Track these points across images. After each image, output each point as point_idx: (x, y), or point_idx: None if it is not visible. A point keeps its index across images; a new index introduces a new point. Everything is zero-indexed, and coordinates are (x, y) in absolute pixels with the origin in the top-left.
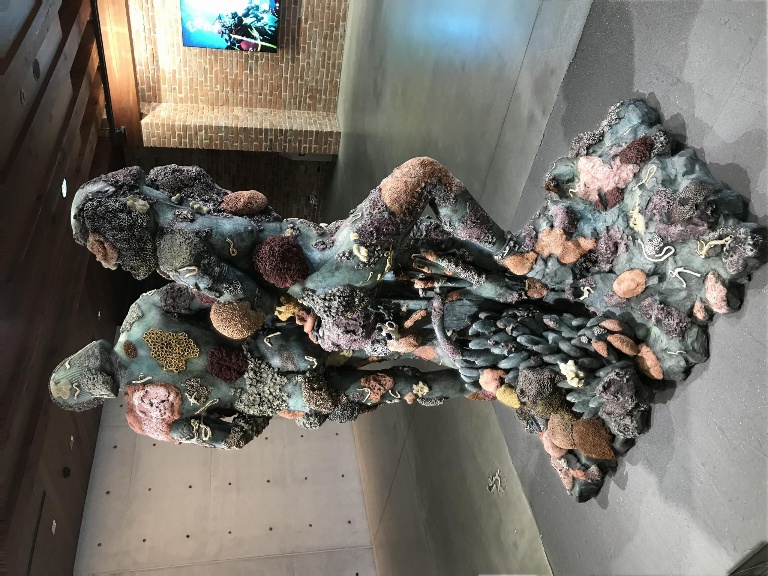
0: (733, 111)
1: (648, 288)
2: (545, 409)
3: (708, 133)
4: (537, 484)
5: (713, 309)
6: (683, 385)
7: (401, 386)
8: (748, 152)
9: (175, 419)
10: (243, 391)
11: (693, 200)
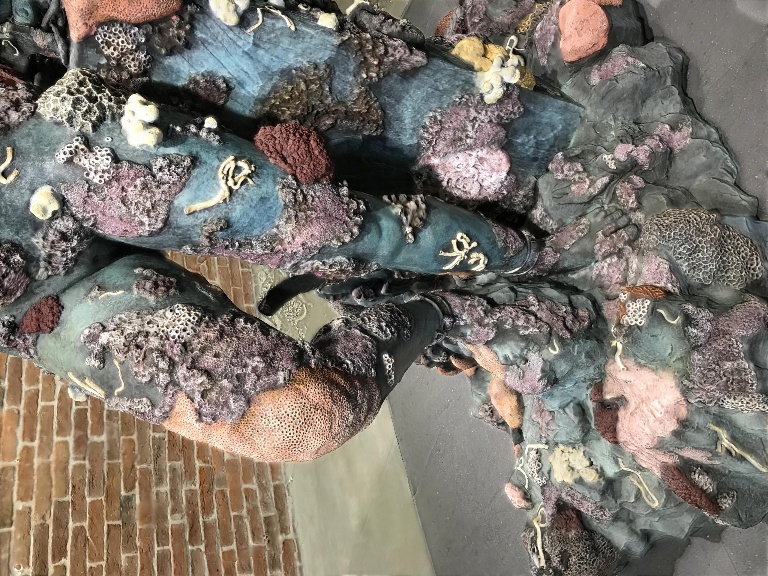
0: None
1: None
2: None
3: (736, 568)
4: (423, 23)
5: None
6: None
7: None
8: None
9: None
10: None
11: None
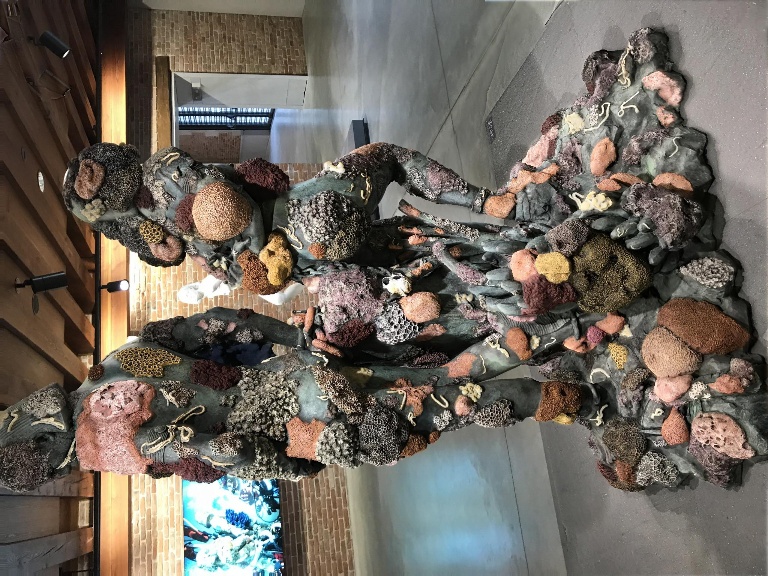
0: None
1: (618, 148)
2: (596, 251)
3: None
4: None
5: (672, 105)
6: (717, 184)
7: (444, 390)
8: (611, 46)
9: (143, 422)
10: (237, 400)
11: (589, 58)
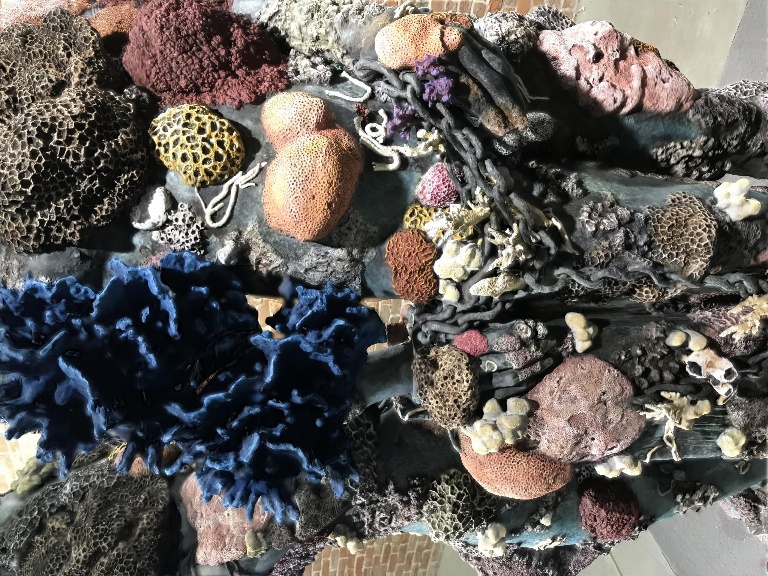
0: (755, 571)
1: None
2: None
3: None
4: None
5: None
6: None
7: None
8: None
9: None
10: None
11: None
